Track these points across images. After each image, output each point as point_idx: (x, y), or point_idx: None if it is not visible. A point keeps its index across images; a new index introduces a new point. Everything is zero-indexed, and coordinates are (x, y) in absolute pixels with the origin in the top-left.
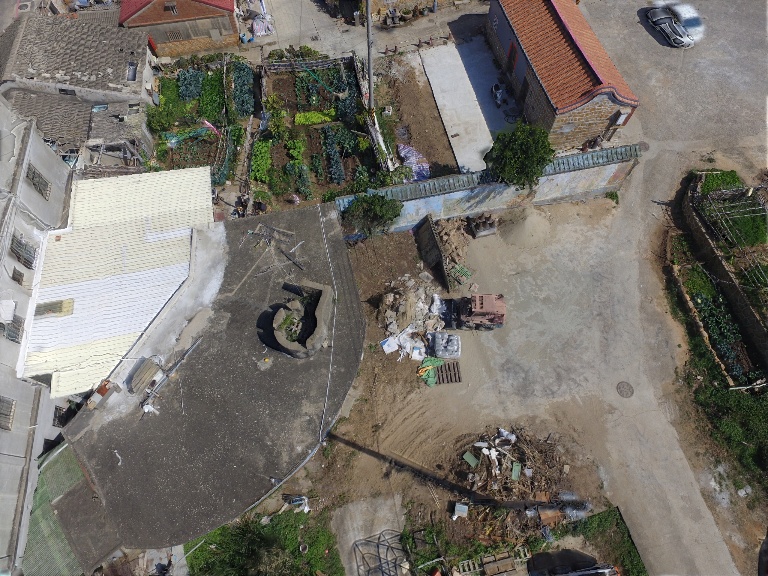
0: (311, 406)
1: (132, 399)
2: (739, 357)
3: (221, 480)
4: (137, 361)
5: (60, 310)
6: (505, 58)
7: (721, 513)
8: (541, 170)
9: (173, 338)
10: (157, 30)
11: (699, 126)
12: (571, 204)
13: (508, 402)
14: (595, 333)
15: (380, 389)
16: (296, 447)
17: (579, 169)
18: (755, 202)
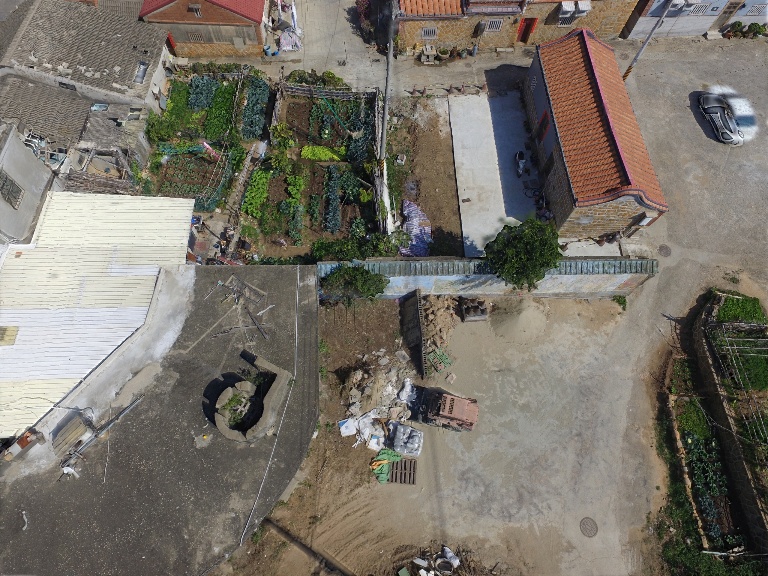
0: (240, 502)
1: (54, 454)
2: (720, 514)
3: (125, 570)
4: (69, 411)
5: (2, 338)
6: (536, 124)
7: None
8: (544, 273)
9: (113, 391)
10: (178, 29)
11: (730, 238)
12: (574, 301)
13: (460, 517)
14: (570, 455)
15: (327, 476)
16: (213, 548)
17: (587, 273)
18: None
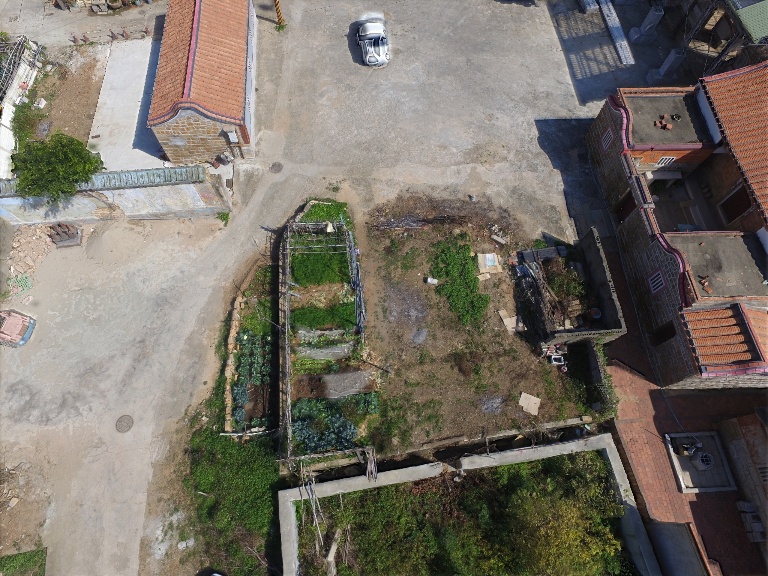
0: None
1: None
2: (257, 401)
3: None
4: None
5: None
6: None
7: (149, 564)
8: (71, 184)
9: None
10: None
11: (343, 152)
12: (177, 221)
13: None
14: (126, 361)
15: None
16: None
17: (143, 186)
18: (341, 239)
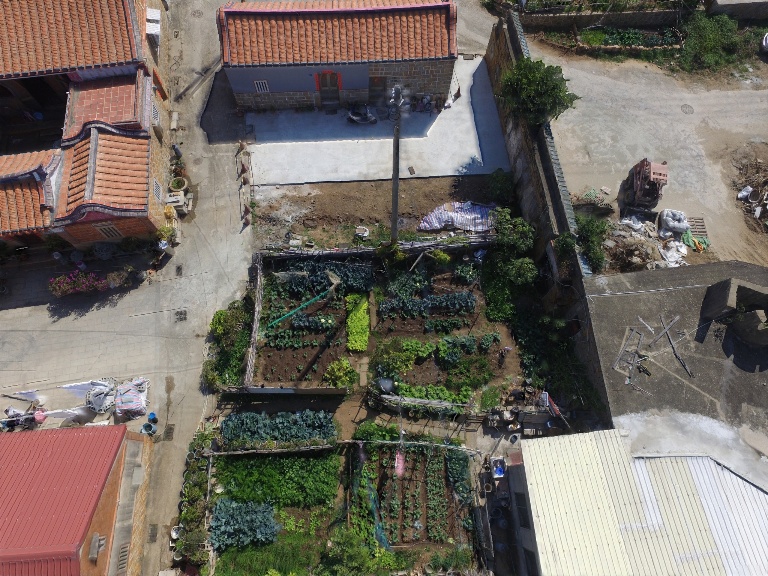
0: None
1: None
2: None
3: None
4: None
5: None
6: (314, 94)
7: (766, 84)
8: None
9: None
10: None
11: None
12: None
13: (713, 188)
14: (641, 114)
15: None
16: None
17: None
18: None
